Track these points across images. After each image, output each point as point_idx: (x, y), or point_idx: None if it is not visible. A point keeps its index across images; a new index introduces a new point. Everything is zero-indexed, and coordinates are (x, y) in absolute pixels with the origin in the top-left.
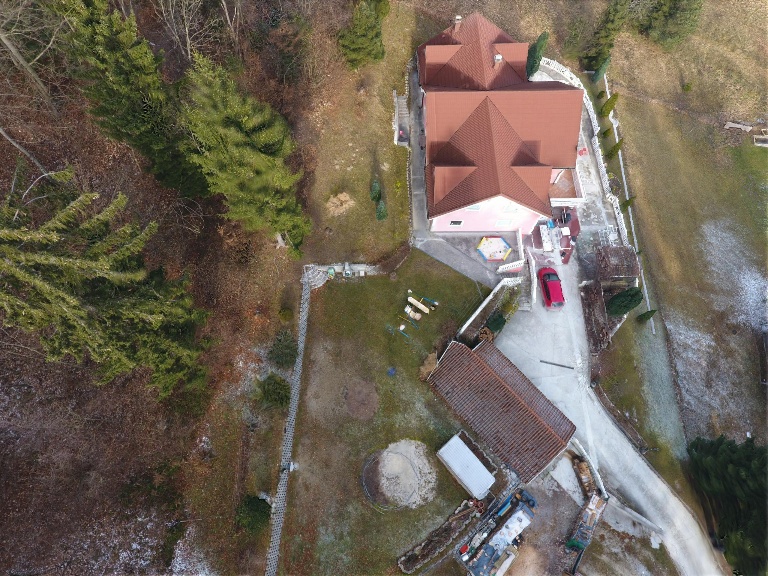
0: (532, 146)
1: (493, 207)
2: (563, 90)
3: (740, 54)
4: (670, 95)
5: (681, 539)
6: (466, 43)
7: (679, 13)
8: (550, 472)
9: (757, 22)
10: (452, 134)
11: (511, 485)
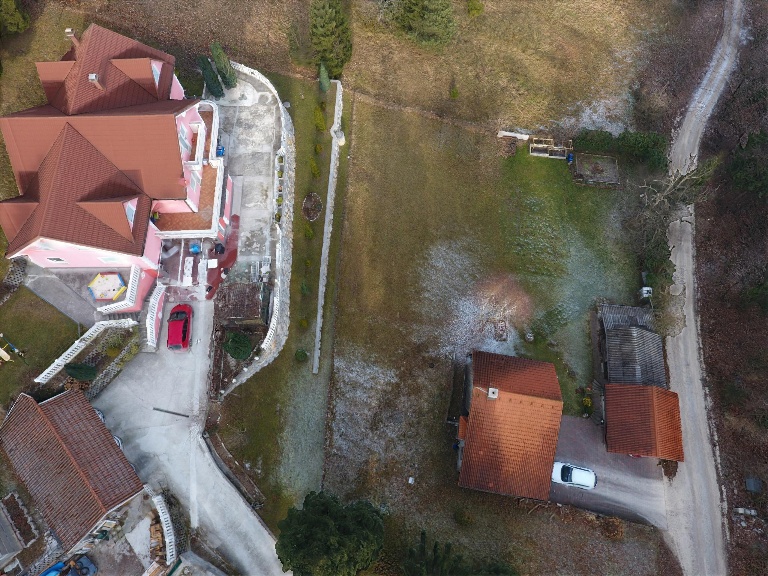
0: (132, 176)
1: (63, 247)
2: (150, 115)
3: (532, 55)
4: (431, 102)
5: None
6: (78, 59)
7: (427, 14)
8: (126, 534)
9: (564, 19)
10: (40, 163)
11: (47, 555)
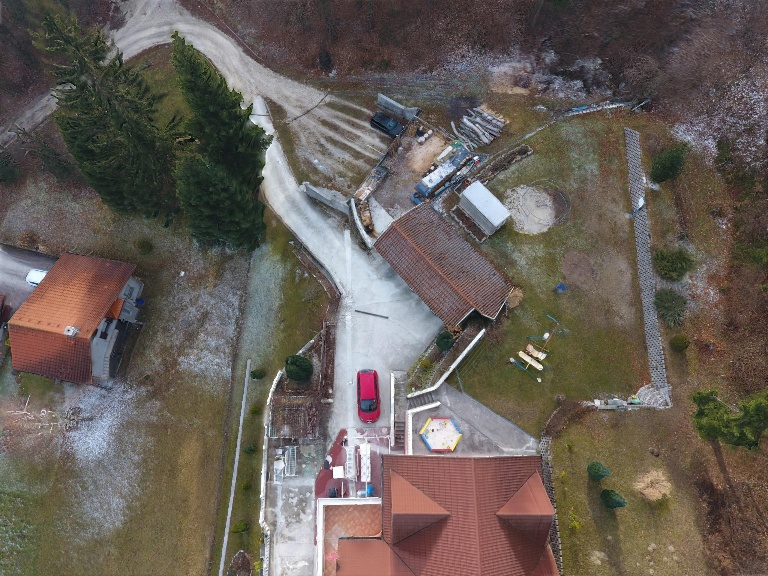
0: (403, 571)
1: None
2: None
3: None
4: None
5: (282, 188)
6: None
7: None
8: None
9: None
10: None
11: (440, 200)
